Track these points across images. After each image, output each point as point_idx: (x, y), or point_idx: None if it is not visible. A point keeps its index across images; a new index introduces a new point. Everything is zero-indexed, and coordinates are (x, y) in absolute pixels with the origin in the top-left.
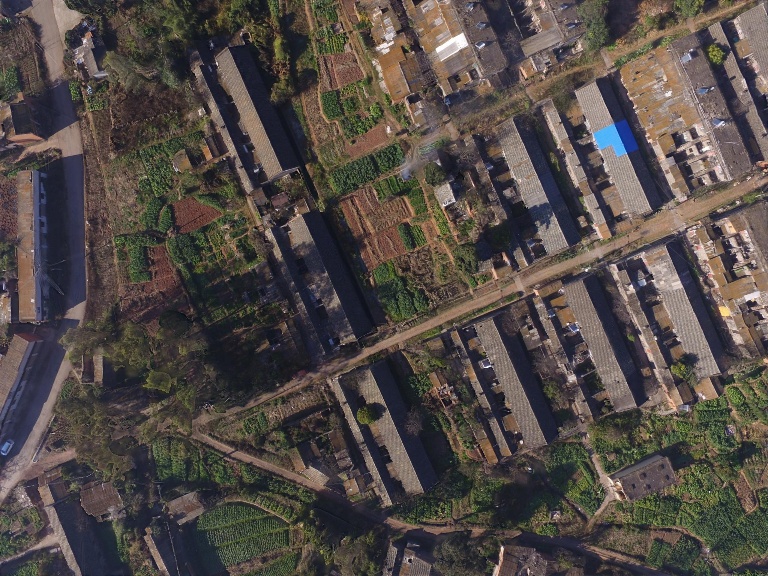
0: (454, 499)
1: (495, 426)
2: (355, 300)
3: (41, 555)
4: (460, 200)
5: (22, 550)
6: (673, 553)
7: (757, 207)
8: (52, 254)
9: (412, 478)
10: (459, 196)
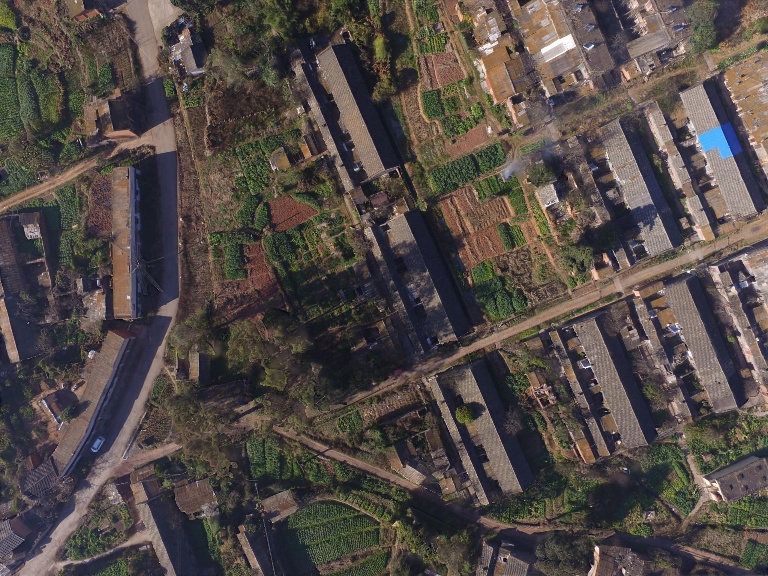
0: (548, 499)
1: (594, 426)
2: (454, 299)
3: (130, 552)
4: (561, 201)
5: (111, 547)
6: (766, 554)
7: None
8: (145, 251)
9: (510, 477)
10: (562, 197)
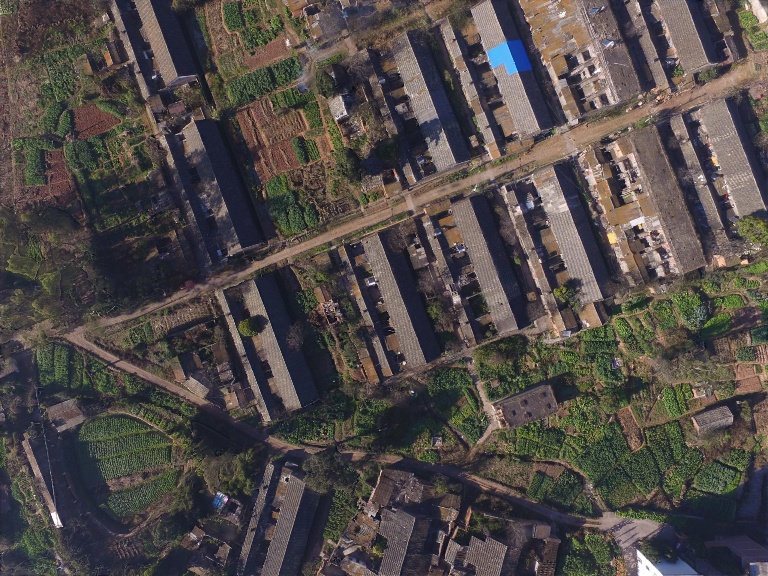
0: (336, 420)
1: (377, 345)
2: (245, 211)
3: None
4: (355, 116)
5: None
6: (555, 487)
7: (644, 130)
8: None
9: (291, 393)
10: (351, 109)
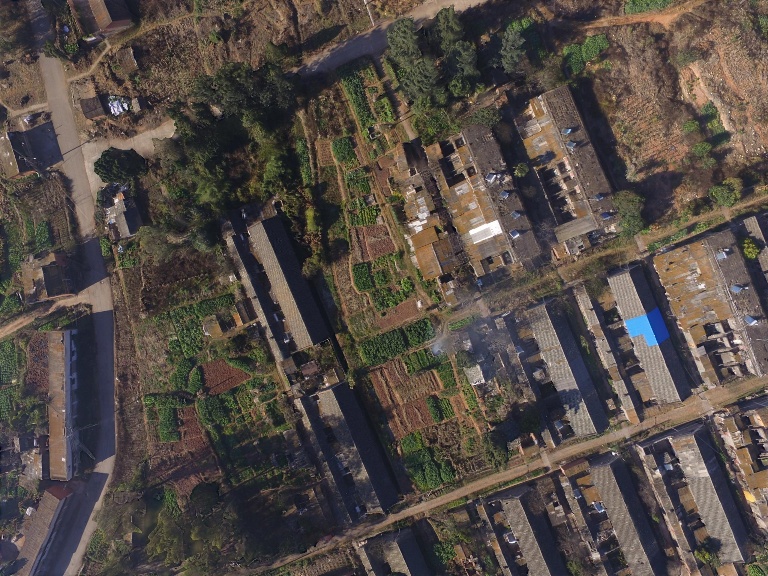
0: None
1: None
2: (382, 471)
3: None
4: None
5: None
6: None
7: None
8: (82, 409)
9: None
10: (489, 376)
